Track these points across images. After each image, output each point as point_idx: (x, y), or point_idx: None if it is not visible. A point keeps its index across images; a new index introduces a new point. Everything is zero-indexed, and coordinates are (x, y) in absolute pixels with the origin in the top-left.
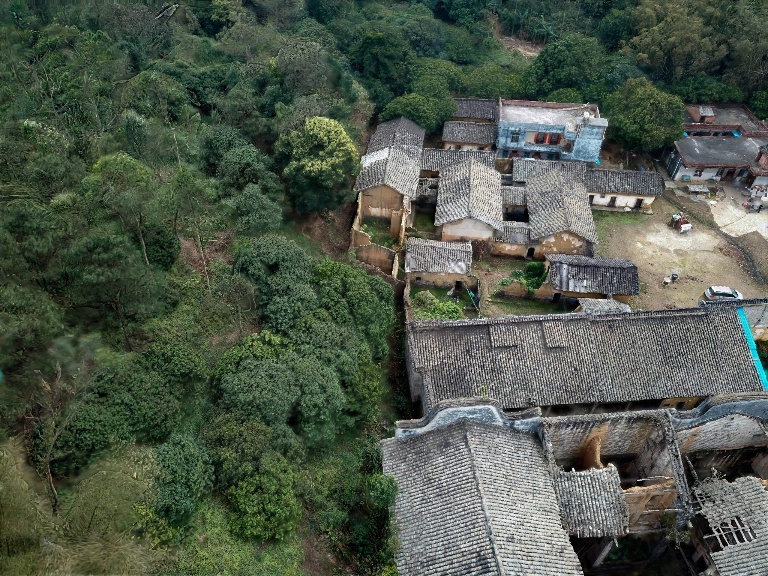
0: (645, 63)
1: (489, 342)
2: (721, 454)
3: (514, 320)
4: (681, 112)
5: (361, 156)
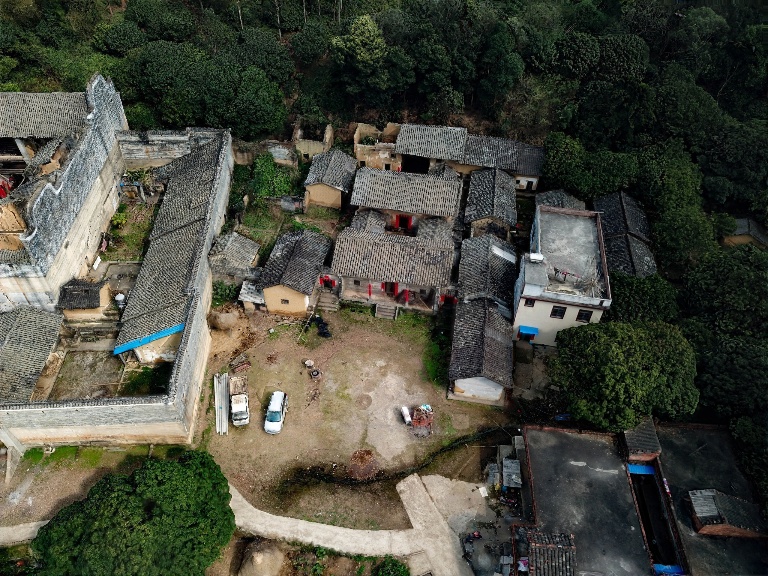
0: None
1: None
2: None
3: None
4: None
5: None
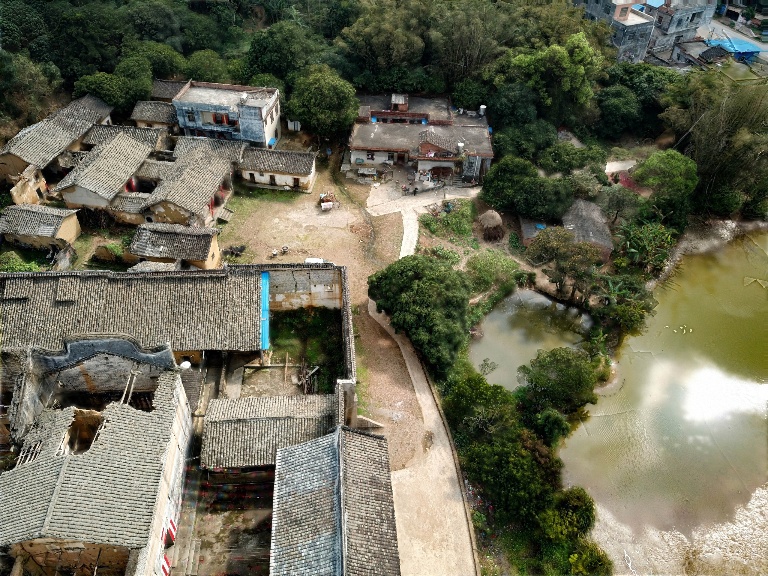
0: (356, 53)
1: (3, 294)
2: (135, 396)
3: (31, 275)
4: (348, 97)
5: (23, 128)
